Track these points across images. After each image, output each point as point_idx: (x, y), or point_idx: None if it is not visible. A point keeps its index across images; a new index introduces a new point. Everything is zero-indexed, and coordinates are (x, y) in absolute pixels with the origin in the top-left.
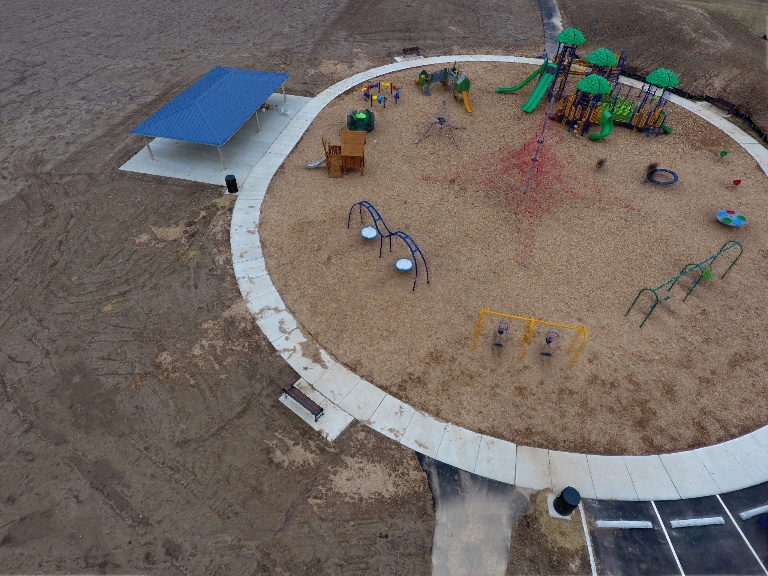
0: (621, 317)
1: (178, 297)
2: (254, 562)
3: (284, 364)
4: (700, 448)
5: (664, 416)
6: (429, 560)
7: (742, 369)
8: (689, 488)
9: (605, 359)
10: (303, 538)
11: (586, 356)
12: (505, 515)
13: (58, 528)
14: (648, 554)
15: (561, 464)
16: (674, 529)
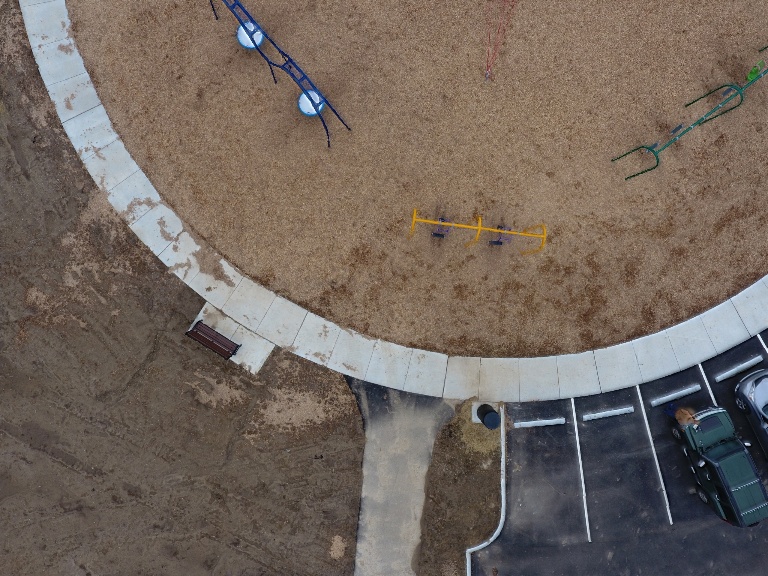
0: (606, 164)
1: (10, 198)
2: (208, 493)
3: (182, 286)
4: (639, 338)
5: (614, 305)
6: (360, 472)
7: (729, 231)
8: (612, 382)
9: (568, 235)
10: (246, 469)
11: (546, 233)
12: (430, 427)
13: (23, 486)
14: (554, 445)
15: (491, 371)
16: (584, 422)
